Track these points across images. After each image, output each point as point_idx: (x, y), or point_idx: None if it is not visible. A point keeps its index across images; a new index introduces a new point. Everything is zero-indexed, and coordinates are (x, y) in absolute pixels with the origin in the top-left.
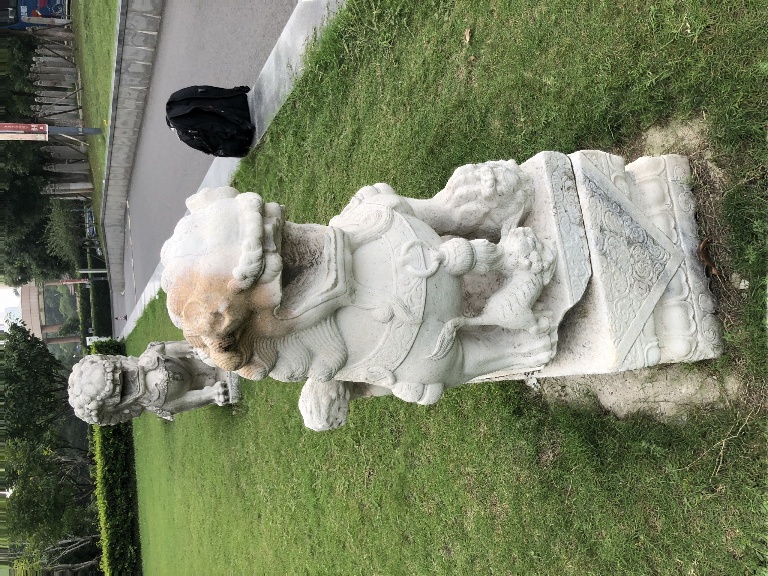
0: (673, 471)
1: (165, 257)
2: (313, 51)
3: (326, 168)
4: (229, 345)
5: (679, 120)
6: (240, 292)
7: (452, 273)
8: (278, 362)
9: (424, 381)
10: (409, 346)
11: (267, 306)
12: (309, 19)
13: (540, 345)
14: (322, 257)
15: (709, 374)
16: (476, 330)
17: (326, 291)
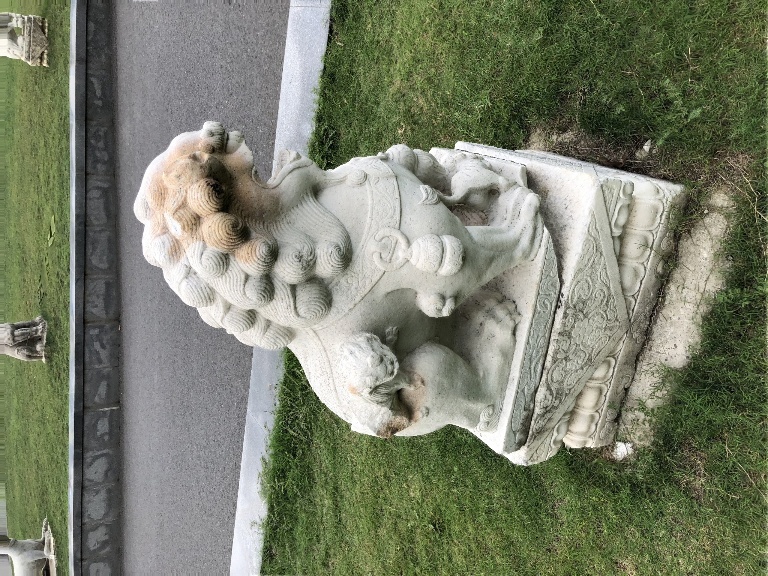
0: (765, 285)
1: (138, 197)
2: (267, 471)
3: (324, 569)
4: (216, 184)
5: (521, 142)
6: (212, 153)
7: (402, 163)
8: (280, 250)
9: (435, 231)
10: (397, 195)
11: (243, 168)
12: (255, 459)
13: (518, 189)
14: (281, 160)
15: (700, 216)
16: (483, 291)
17: (293, 160)
